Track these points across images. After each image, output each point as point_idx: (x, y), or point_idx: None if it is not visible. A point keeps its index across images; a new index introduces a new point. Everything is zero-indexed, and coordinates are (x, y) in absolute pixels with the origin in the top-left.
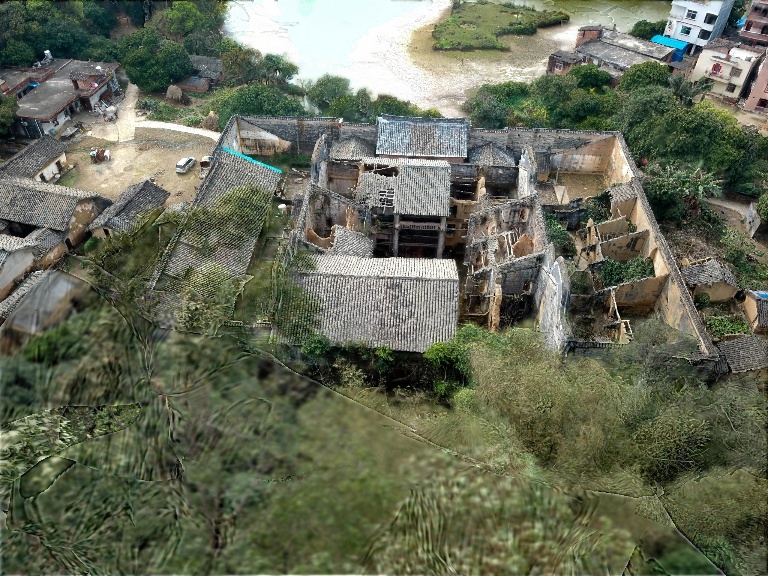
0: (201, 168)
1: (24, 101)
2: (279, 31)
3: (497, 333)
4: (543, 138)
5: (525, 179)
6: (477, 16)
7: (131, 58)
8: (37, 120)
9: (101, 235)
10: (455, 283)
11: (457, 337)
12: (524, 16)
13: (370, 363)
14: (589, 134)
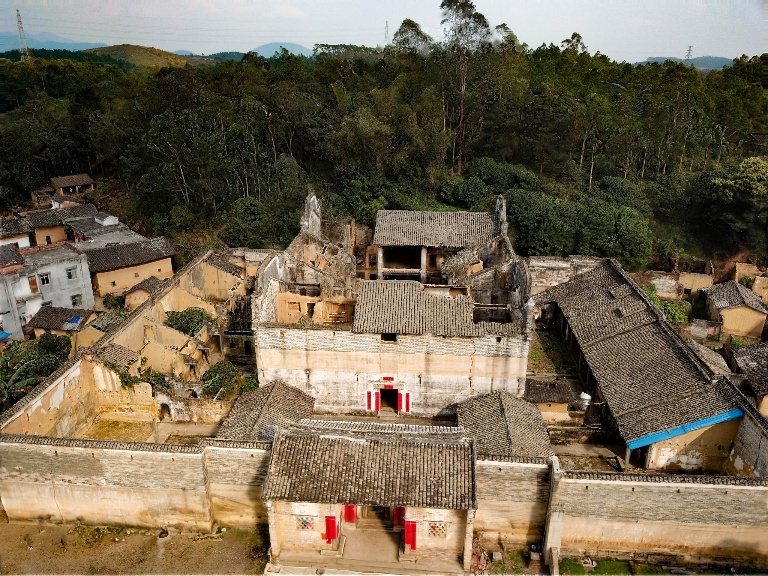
0: None
1: None
2: None
3: None
4: None
5: None
6: None
7: None
8: None
9: None
10: None
11: None
12: None
13: None
14: None
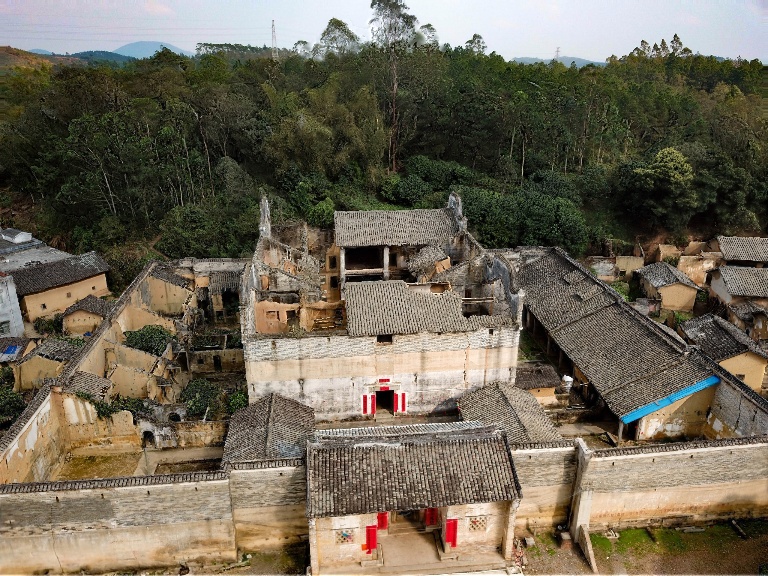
0: None
1: None
2: None
3: None
4: None
5: None
6: None
7: None
8: None
9: None
10: None
11: None
12: None
13: None
14: None
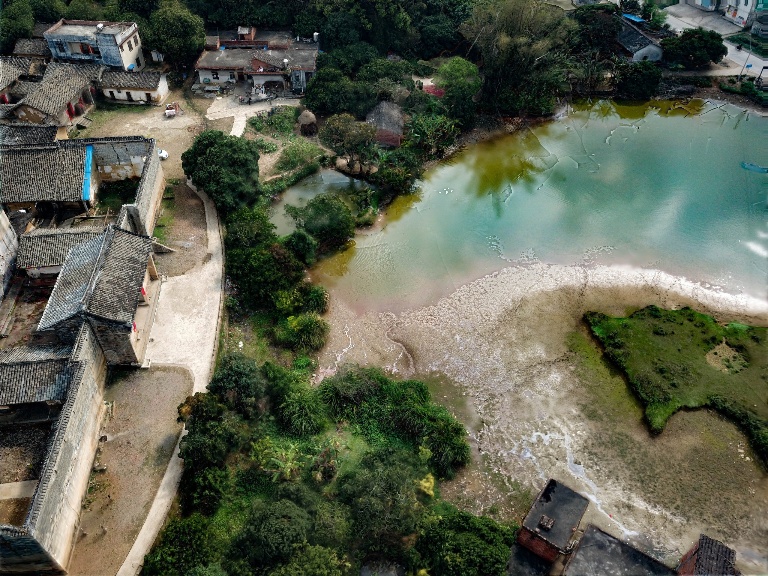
0: None
1: (230, 51)
2: None
3: None
4: None
5: None
6: None
7: None
8: None
9: None
10: None
11: None
12: None
13: None
14: None
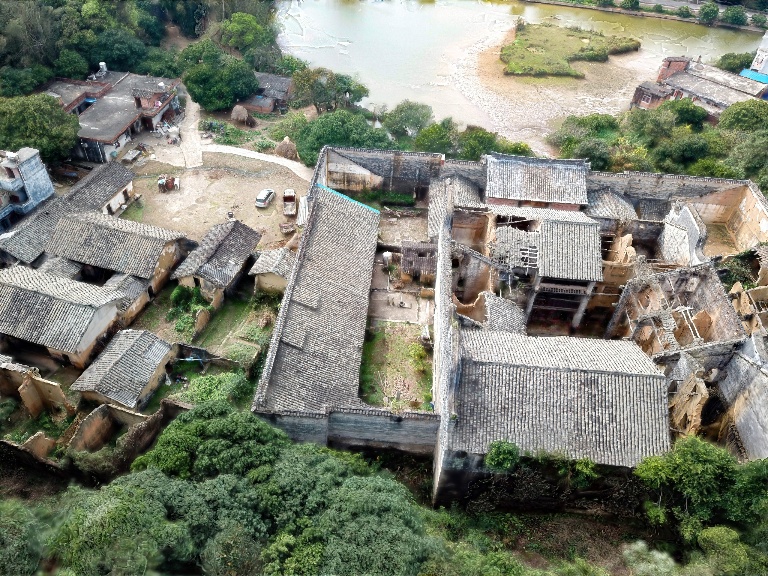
0: (284, 203)
1: (82, 119)
2: (338, 47)
3: (695, 435)
4: (666, 184)
5: (682, 240)
6: (544, 39)
7: (194, 74)
8: (99, 142)
9: (189, 284)
10: (662, 380)
11: (680, 453)
12: (593, 41)
13: (566, 477)
14: (718, 182)
